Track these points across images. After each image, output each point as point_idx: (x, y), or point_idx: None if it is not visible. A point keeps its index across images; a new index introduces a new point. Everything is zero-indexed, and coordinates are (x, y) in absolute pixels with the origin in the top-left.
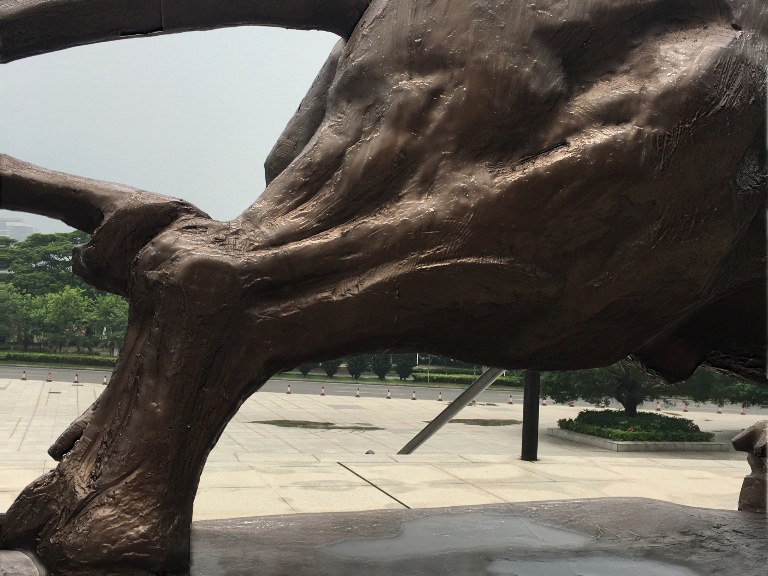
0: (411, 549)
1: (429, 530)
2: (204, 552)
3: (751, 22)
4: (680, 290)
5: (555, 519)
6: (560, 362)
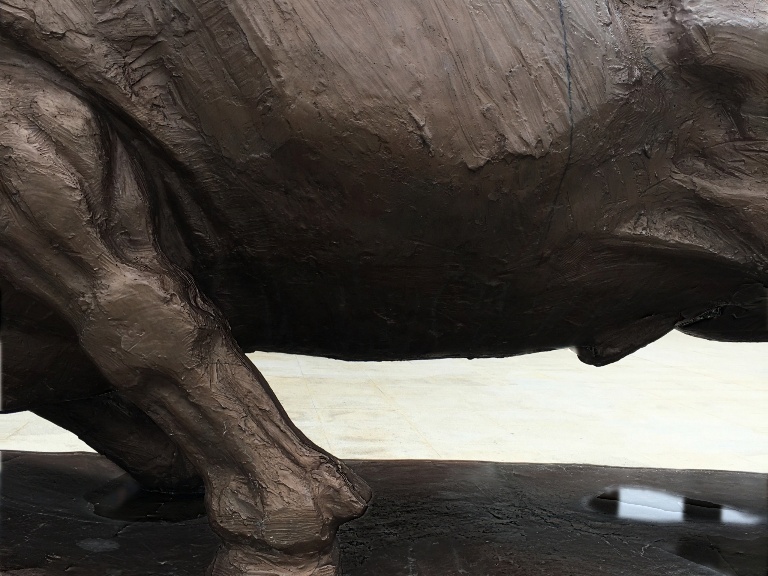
0: None
1: None
2: None
3: None
4: None
5: (694, 573)
6: (722, 332)
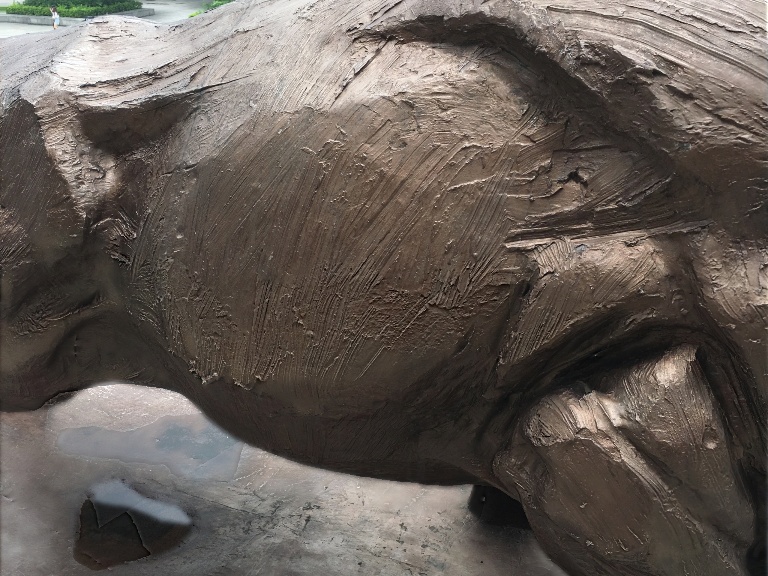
0: (104, 448)
1: (159, 431)
2: (6, 415)
3: (13, 201)
4: (2, 391)
5: None
6: None
